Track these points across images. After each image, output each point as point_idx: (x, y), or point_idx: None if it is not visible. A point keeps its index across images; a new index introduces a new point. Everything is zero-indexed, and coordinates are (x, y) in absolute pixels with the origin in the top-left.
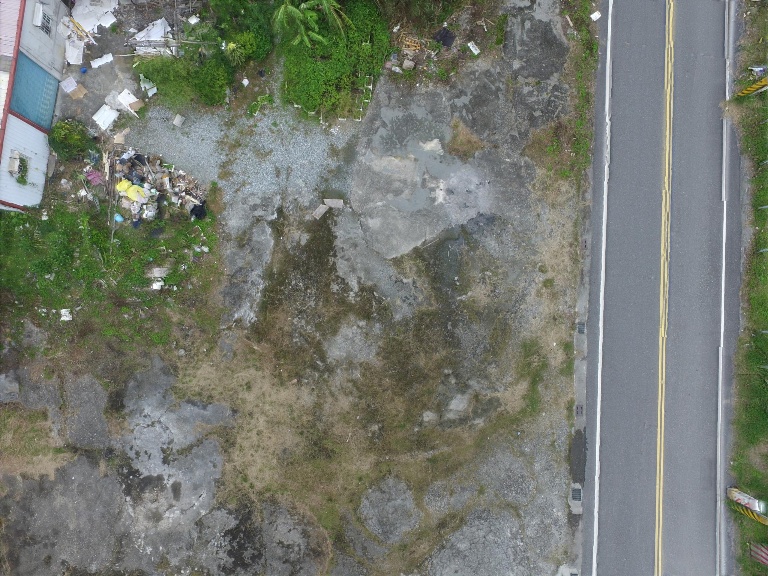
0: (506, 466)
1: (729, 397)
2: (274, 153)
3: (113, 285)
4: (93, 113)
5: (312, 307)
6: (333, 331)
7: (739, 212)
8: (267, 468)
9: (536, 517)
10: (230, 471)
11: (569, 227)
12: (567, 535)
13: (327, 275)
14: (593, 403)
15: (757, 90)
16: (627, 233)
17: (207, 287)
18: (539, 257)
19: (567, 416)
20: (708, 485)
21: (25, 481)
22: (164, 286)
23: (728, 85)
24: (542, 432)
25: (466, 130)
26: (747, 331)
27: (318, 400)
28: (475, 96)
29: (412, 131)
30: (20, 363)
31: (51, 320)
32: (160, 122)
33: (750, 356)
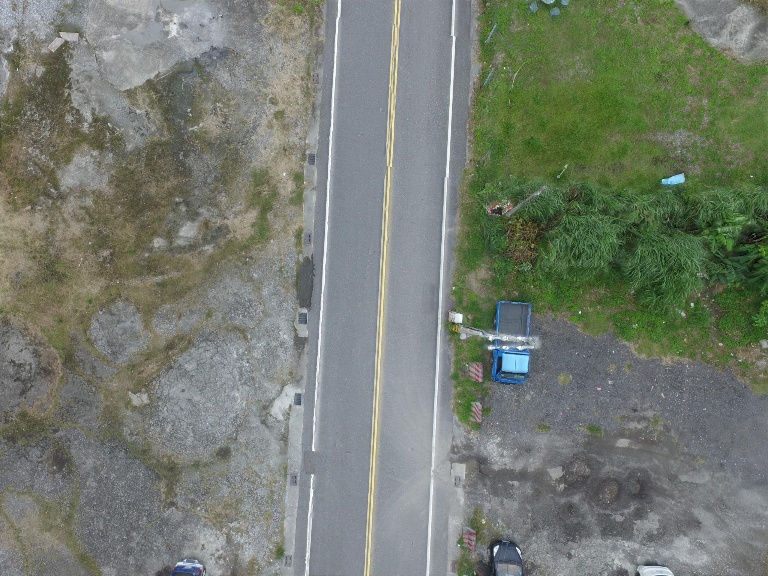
0: (234, 290)
1: (453, 226)
2: None
3: None
4: None
5: (47, 137)
6: (67, 160)
7: (469, 48)
8: None
9: (262, 339)
10: None
11: (301, 61)
12: (292, 357)
13: (62, 106)
14: (321, 231)
15: None
16: (358, 67)
17: None
18: (270, 90)
19: (295, 243)
20: (430, 309)
21: None
22: None
23: None
24: (270, 258)
25: None
26: (473, 162)
27: (51, 226)
28: None
29: None
30: None
31: None
32: None
33: (472, 185)
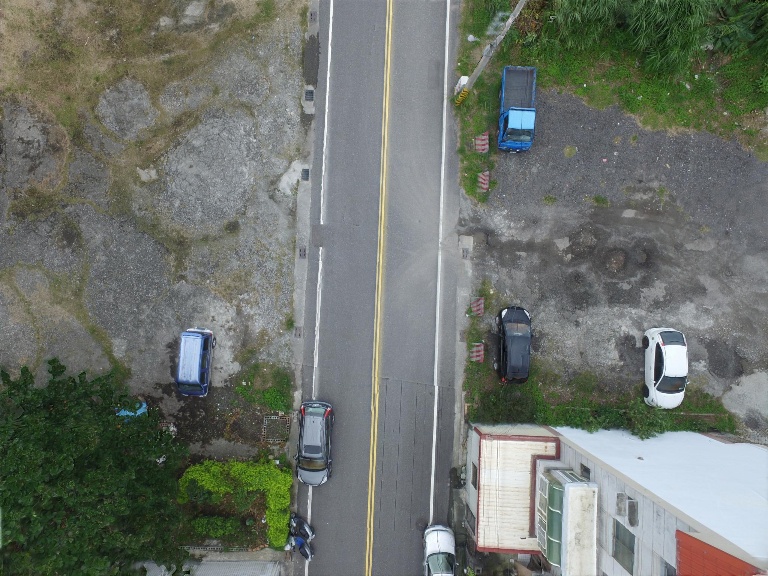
0: (240, 68)
1: (458, 3)
2: None
3: None
4: None
5: None
6: None
7: None
8: (7, 68)
9: (269, 116)
10: None
11: None
12: (300, 133)
13: None
14: (326, 9)
15: None
16: None
17: None
18: None
19: (300, 21)
20: (436, 85)
21: None
22: None
23: None
24: (276, 36)
25: None
26: None
27: (57, 5)
28: None
29: None
30: None
31: None
32: None
33: None
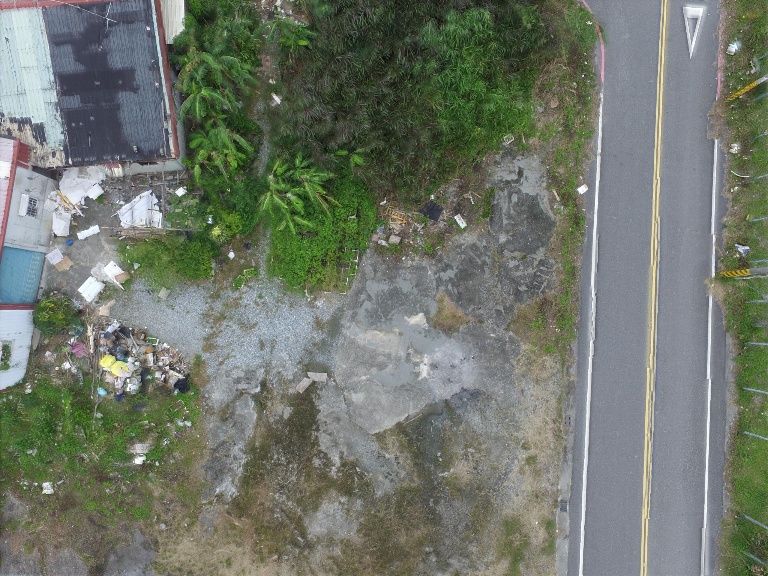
0: None
1: None
2: (259, 326)
3: (95, 460)
4: (79, 285)
5: (294, 482)
6: (314, 507)
7: (724, 390)
8: None
9: None
10: None
11: (553, 403)
12: None
13: (310, 449)
14: None
15: (742, 277)
16: (611, 410)
17: (189, 461)
18: (522, 434)
19: None
20: None
21: None
22: (146, 461)
23: (714, 261)
24: None
25: (451, 304)
26: (730, 512)
27: None
28: (461, 270)
29: (397, 305)
30: (0, 537)
31: (32, 494)
32: (145, 294)
33: (733, 539)
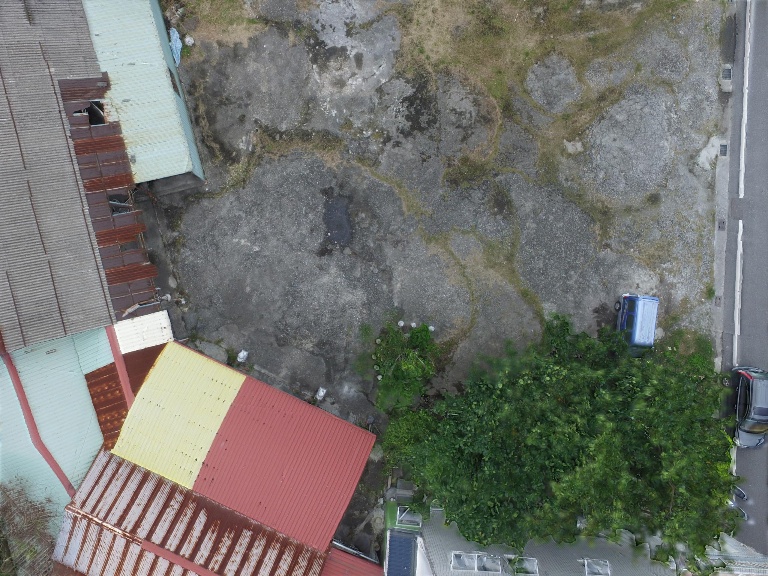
0: (662, 46)
1: None
2: None
3: None
4: None
5: None
6: None
7: None
8: (442, 42)
9: (689, 93)
10: (408, 44)
11: None
12: (717, 111)
13: None
14: None
15: None
16: None
17: None
18: None
19: (719, 3)
20: None
21: (221, 48)
22: None
23: None
24: (695, 16)
25: None
26: None
27: None
28: None
29: None
30: None
31: None
32: None
33: None
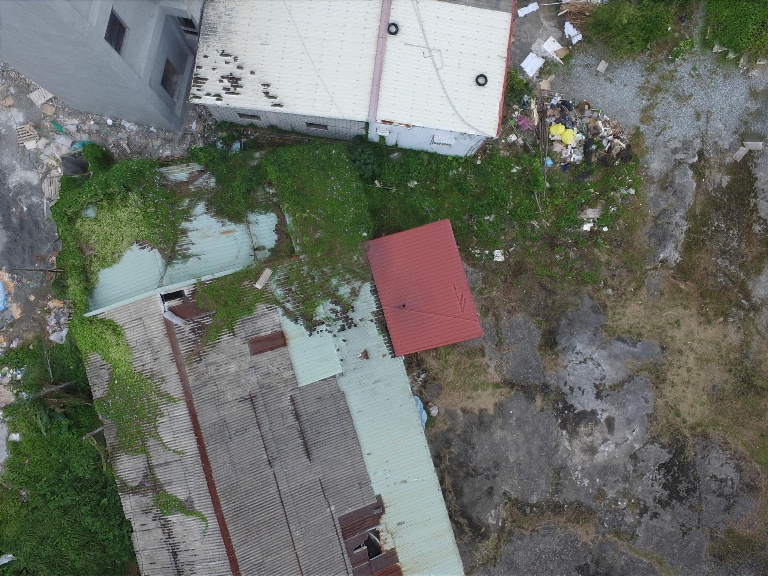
0: None
1: None
2: (694, 97)
3: (545, 226)
4: (521, 60)
5: (735, 247)
6: (758, 271)
7: None
8: (698, 404)
9: None
10: (662, 406)
11: None
12: None
13: (749, 216)
14: None
15: None
16: None
17: (634, 228)
18: None
19: None
20: None
21: (465, 415)
22: (593, 227)
23: None
24: None
25: None
26: None
27: (745, 338)
28: None
29: None
30: None
31: (485, 261)
32: (583, 68)
33: None
